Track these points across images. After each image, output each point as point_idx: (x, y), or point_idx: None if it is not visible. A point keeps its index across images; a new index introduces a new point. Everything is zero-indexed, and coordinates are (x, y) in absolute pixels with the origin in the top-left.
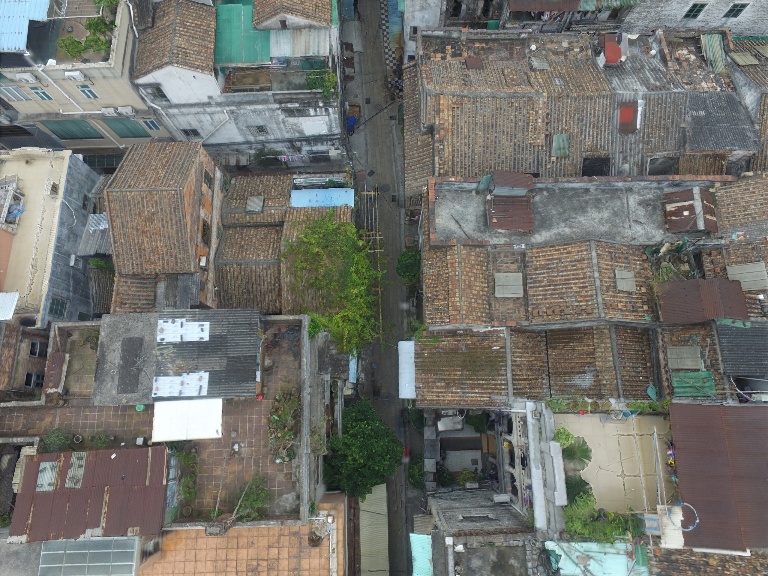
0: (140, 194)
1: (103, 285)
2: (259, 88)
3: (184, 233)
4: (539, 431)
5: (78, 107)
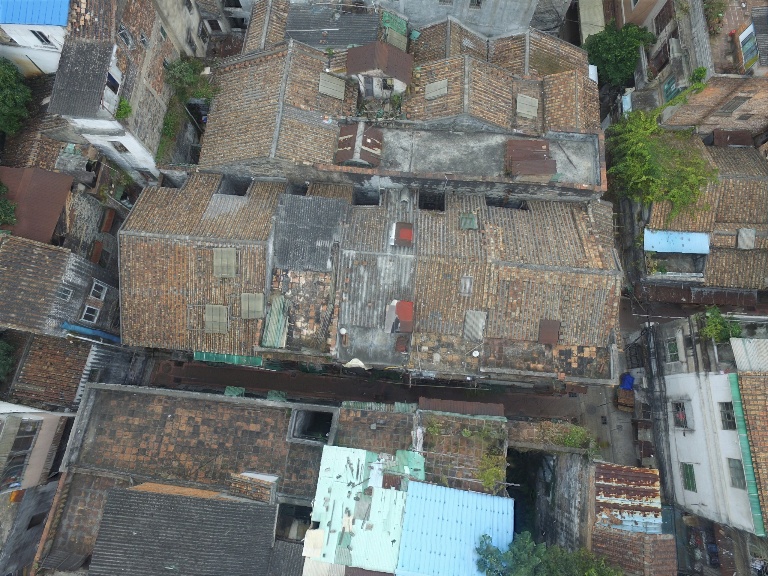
0: None
1: None
2: None
3: None
4: None
5: None
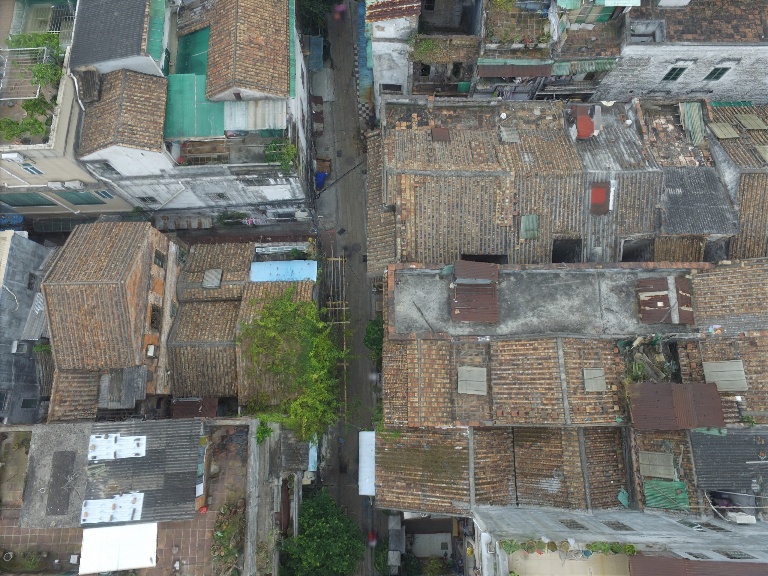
0: (79, 287)
1: (50, 368)
2: (216, 157)
3: (127, 328)
4: (494, 567)
5: (23, 181)
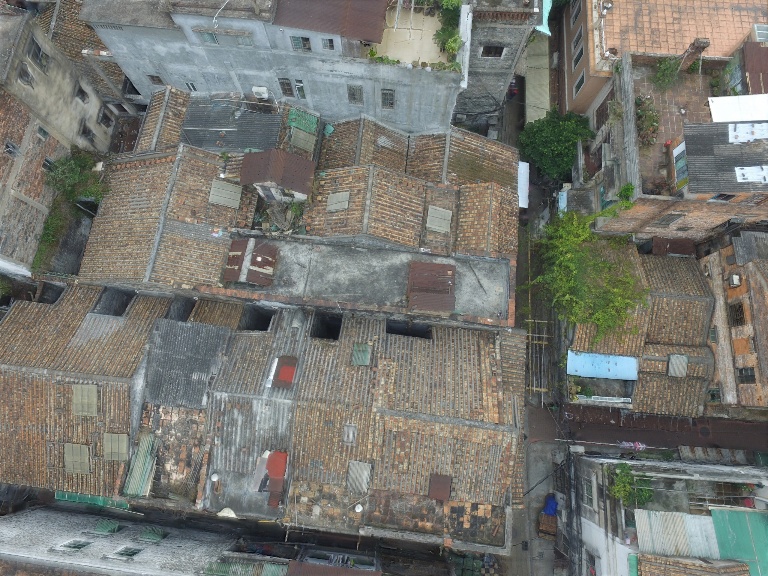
0: None
1: None
2: None
3: None
4: None
5: None
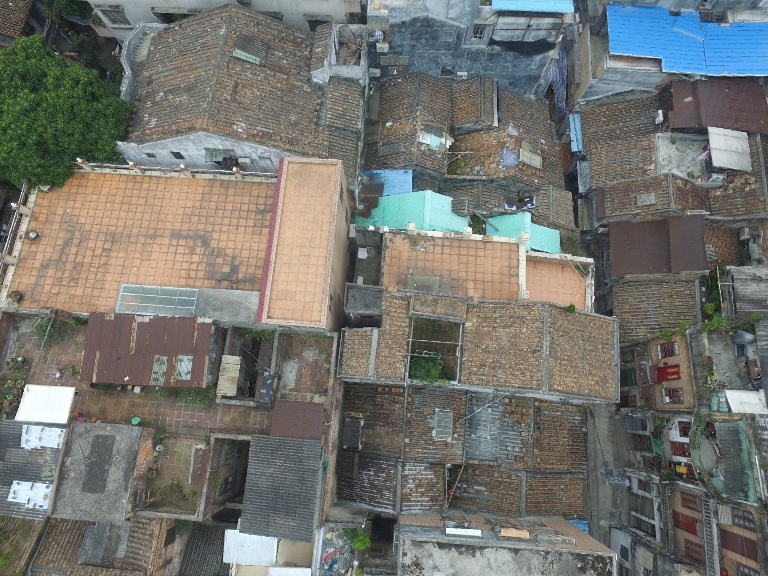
0: None
1: None
2: None
3: None
4: None
5: None
